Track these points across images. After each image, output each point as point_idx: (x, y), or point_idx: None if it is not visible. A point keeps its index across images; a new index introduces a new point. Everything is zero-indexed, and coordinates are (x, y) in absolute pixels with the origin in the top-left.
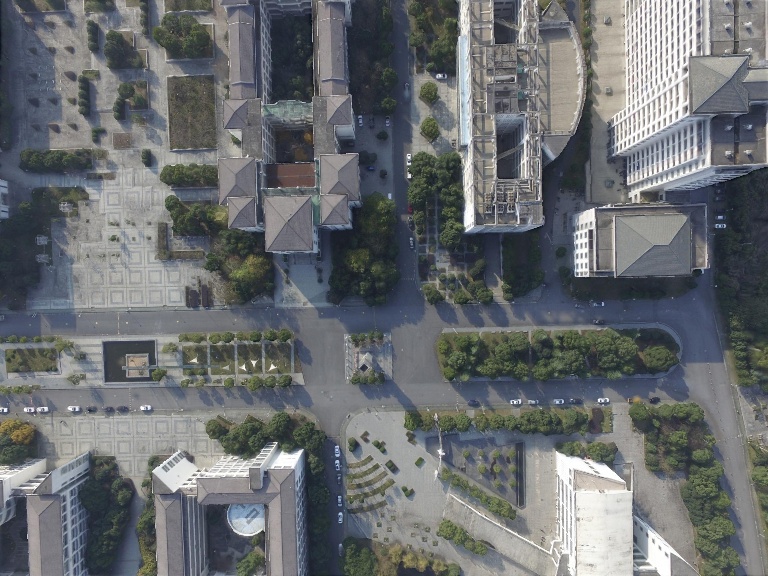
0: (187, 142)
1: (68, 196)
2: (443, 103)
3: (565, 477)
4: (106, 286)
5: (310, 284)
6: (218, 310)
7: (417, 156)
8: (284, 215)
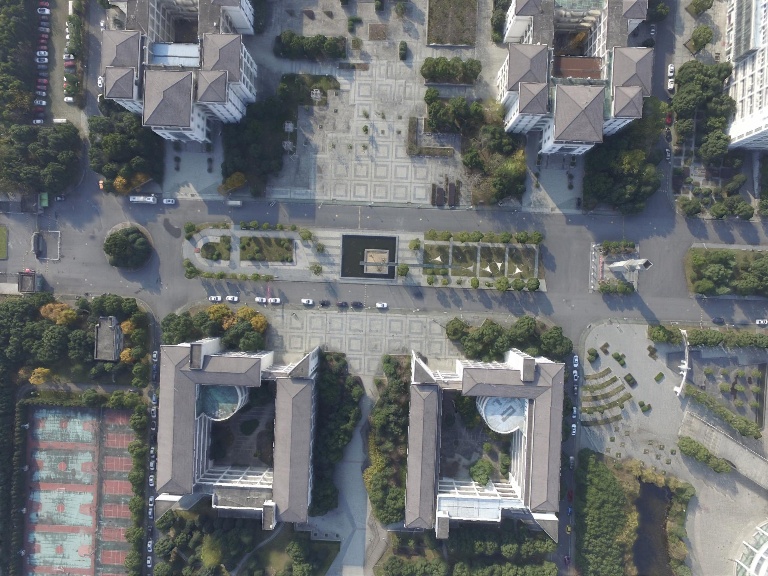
0: (446, 37)
1: (319, 84)
2: (709, 16)
3: None
4: (350, 178)
5: (560, 190)
6: (463, 210)
7: (690, 63)
8: (580, 103)
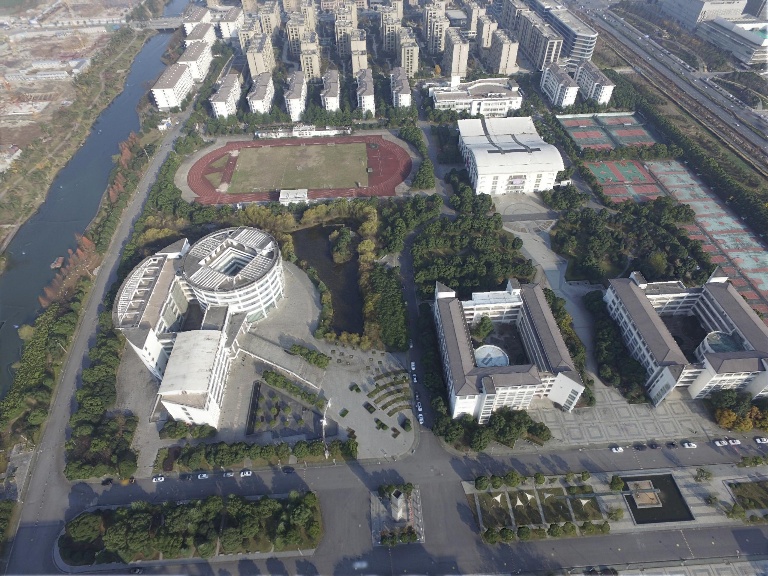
0: None
1: None
2: None
3: (214, 405)
4: None
5: None
6: (577, 567)
7: None
8: None
